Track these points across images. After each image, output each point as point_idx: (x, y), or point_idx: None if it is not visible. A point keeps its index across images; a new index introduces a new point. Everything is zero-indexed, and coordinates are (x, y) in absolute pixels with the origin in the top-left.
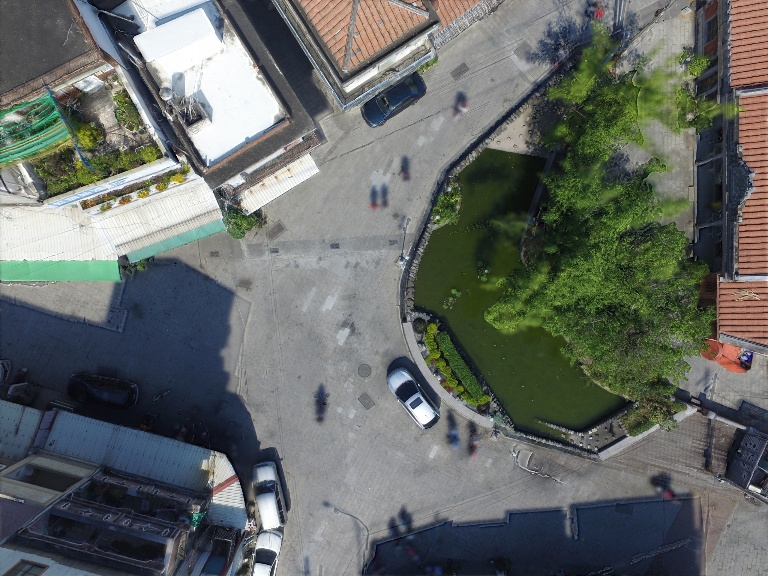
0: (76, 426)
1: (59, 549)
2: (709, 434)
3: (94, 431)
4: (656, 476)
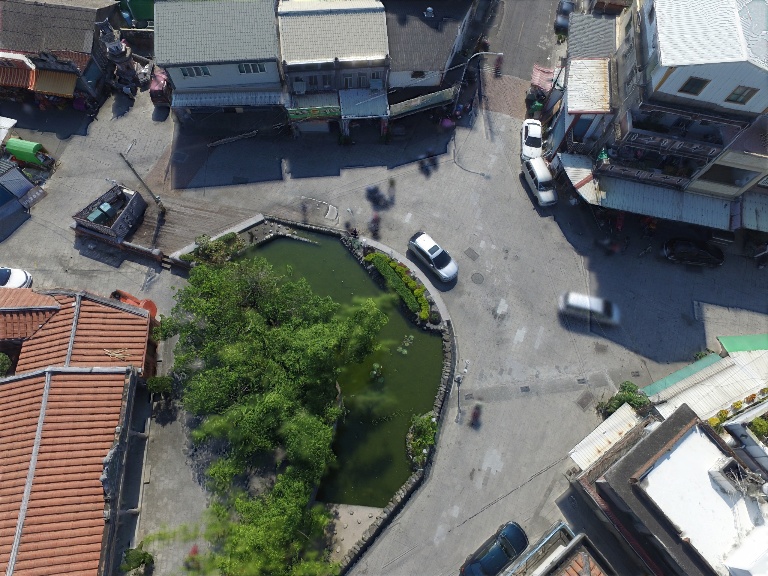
0: (712, 219)
1: (718, 115)
2: (158, 238)
3: (697, 216)
4: (211, 205)
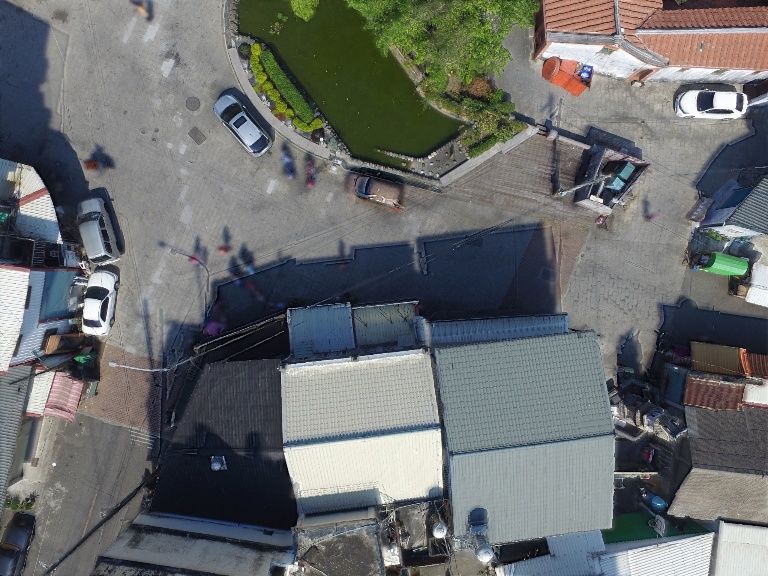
0: None
1: None
2: (555, 158)
3: None
4: (503, 205)
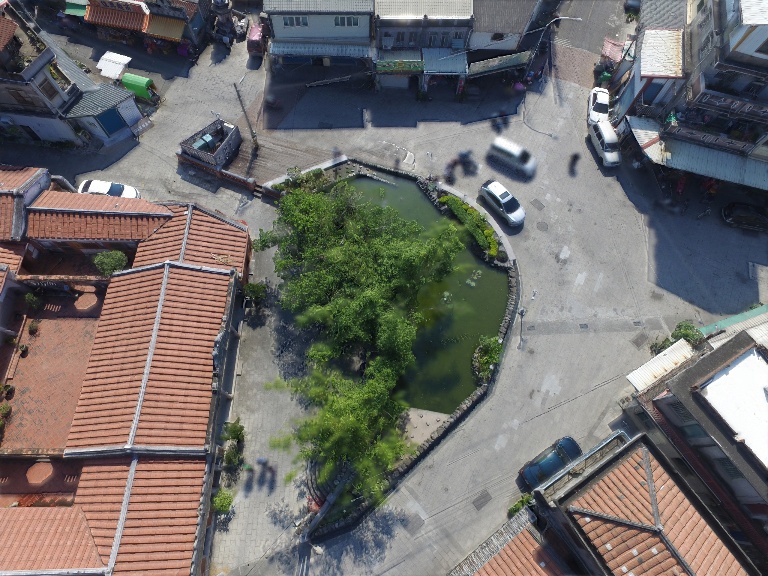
0: None
1: None
2: (251, 170)
3: (758, 180)
4: (299, 144)
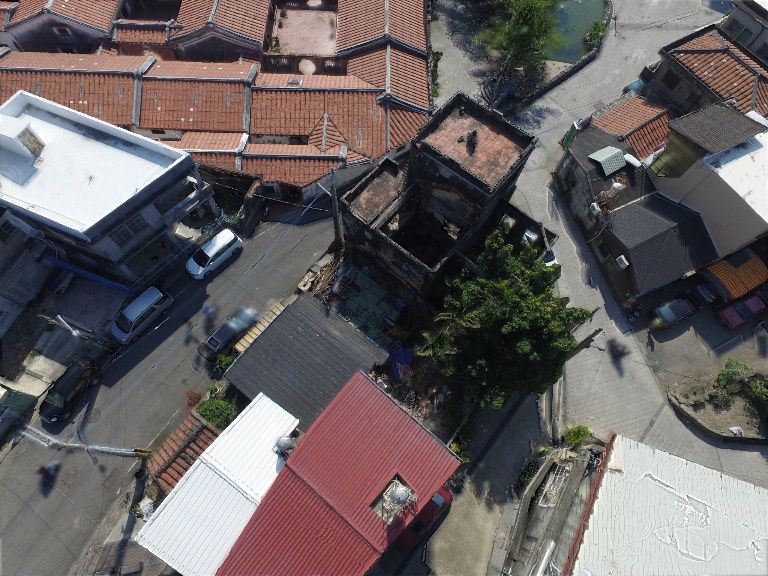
0: None
1: None
2: None
3: None
4: None
